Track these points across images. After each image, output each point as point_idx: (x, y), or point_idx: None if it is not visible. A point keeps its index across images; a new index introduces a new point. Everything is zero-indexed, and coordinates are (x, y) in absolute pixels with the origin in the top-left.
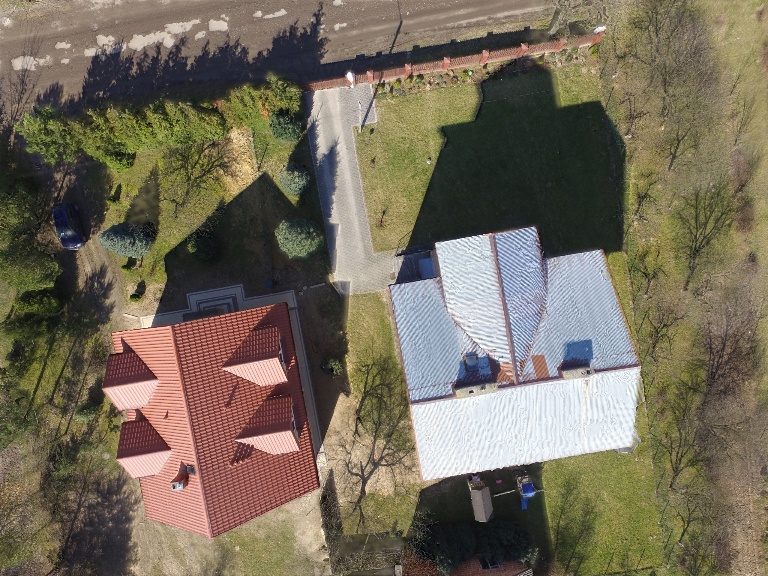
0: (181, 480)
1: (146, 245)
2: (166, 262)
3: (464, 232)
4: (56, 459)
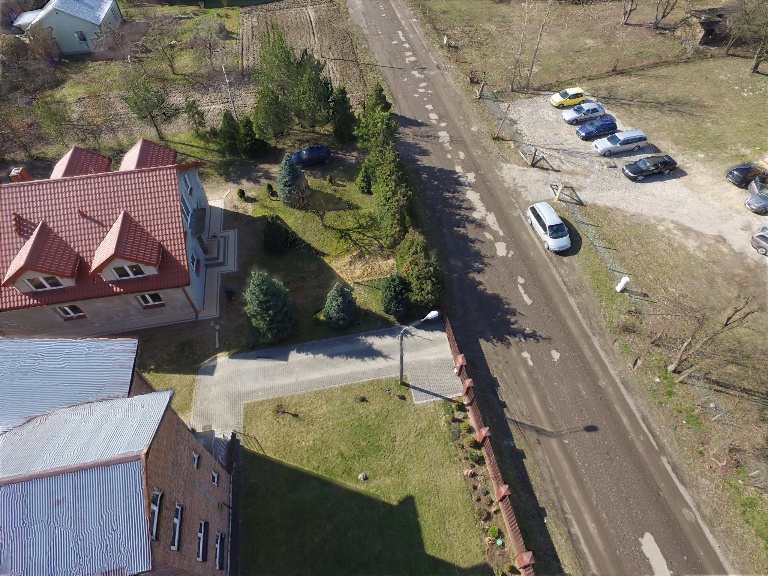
0: (21, 175)
1: (287, 198)
2: None
3: (250, 538)
4: (121, 154)
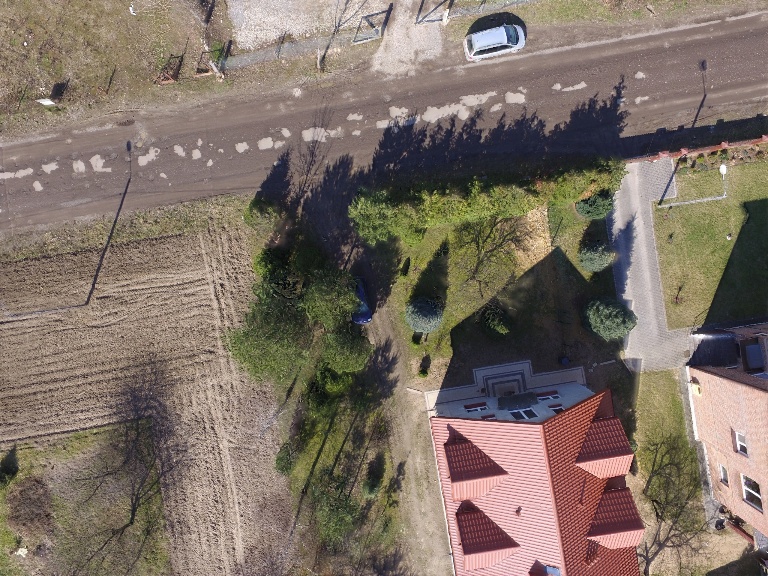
0: None
1: None
2: (452, 336)
3: (764, 310)
4: None
